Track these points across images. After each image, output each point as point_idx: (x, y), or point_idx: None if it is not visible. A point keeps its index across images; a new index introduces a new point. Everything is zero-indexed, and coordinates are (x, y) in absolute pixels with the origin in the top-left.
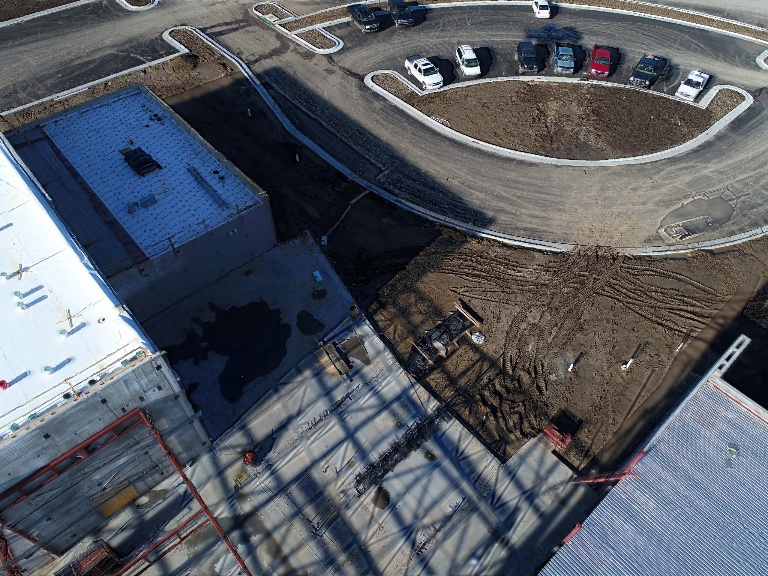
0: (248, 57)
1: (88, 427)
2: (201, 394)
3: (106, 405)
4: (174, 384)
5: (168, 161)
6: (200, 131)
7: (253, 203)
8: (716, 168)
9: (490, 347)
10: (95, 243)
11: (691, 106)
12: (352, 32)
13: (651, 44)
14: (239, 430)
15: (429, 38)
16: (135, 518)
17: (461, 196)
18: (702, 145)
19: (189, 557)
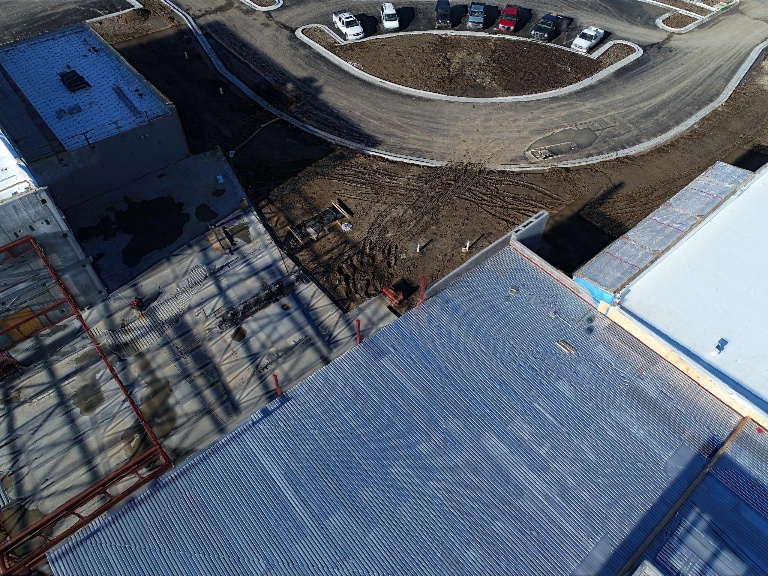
0: (195, 12)
1: None
2: (106, 261)
3: None
4: (61, 222)
5: (98, 82)
6: (141, 70)
7: (163, 113)
8: (592, 106)
9: (355, 233)
10: (24, 139)
11: (584, 56)
12: None
13: (563, 6)
14: (132, 286)
15: None
16: (38, 343)
17: (360, 123)
18: (585, 88)
19: (76, 369)
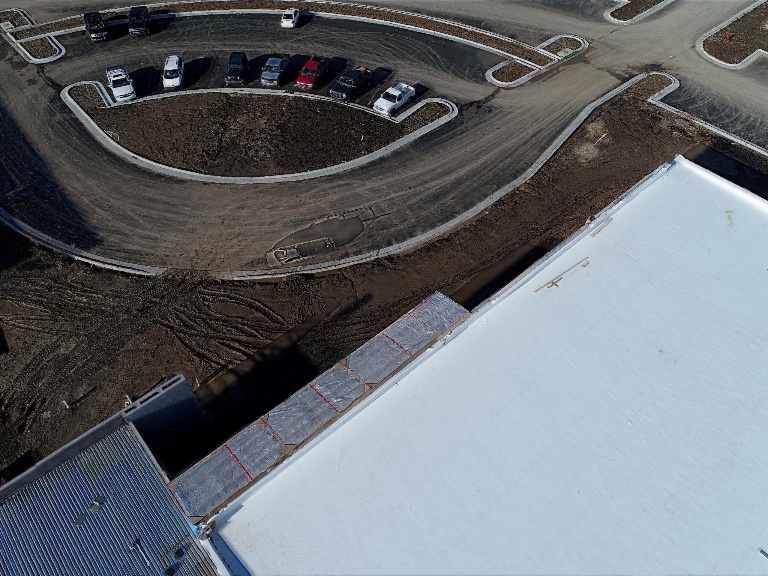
0: None
1: None
2: None
3: None
4: None
5: None
6: None
7: None
8: (372, 186)
9: None
10: None
11: (386, 120)
12: (82, 41)
13: (386, 55)
14: None
15: (158, 48)
16: None
17: (82, 215)
18: (373, 161)
19: None
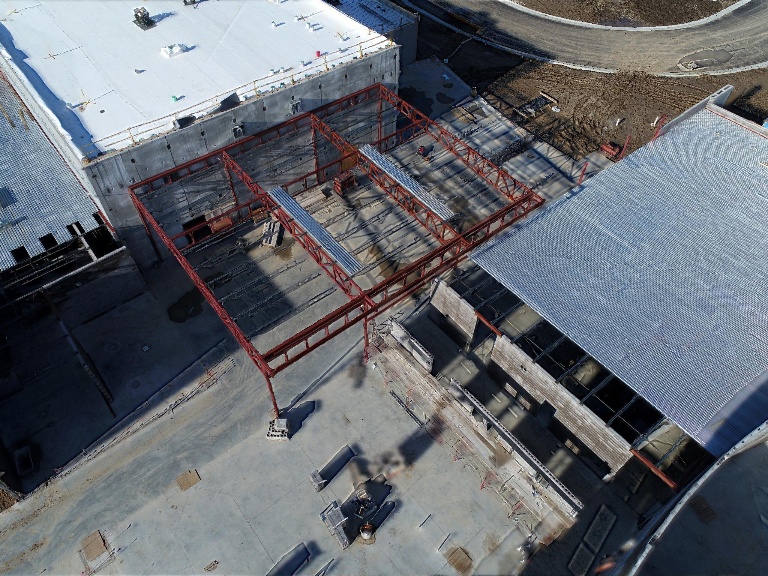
0: None
1: (360, 82)
2: None
3: (370, 70)
4: (397, 76)
5: (345, 1)
6: None
7: (407, 23)
8: (721, 34)
9: (564, 113)
10: None
11: None
12: None
13: None
14: (410, 142)
15: None
16: (357, 174)
17: (537, 43)
18: (712, 22)
19: None
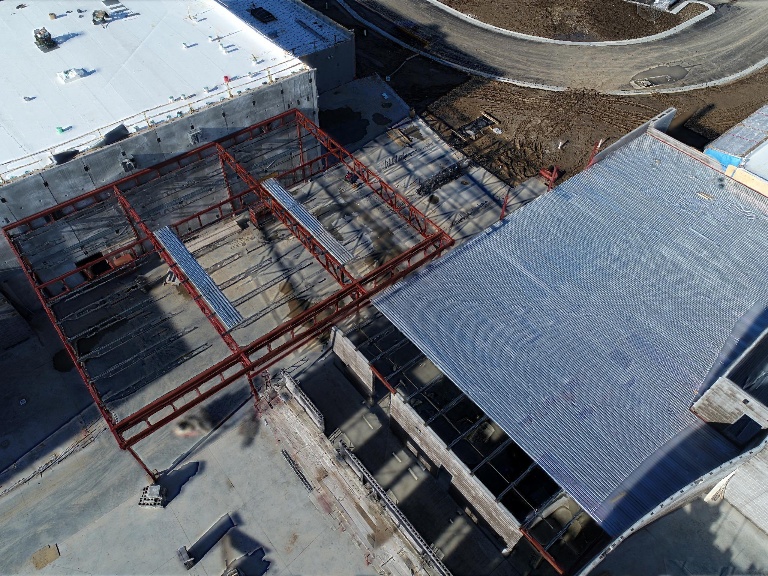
0: None
1: (271, 109)
2: None
3: (282, 96)
4: (315, 100)
5: (281, 16)
6: None
7: (344, 40)
8: (679, 49)
9: (505, 135)
10: None
11: (665, 12)
12: None
13: None
14: (339, 167)
15: None
16: None
17: (486, 59)
18: (670, 36)
19: None
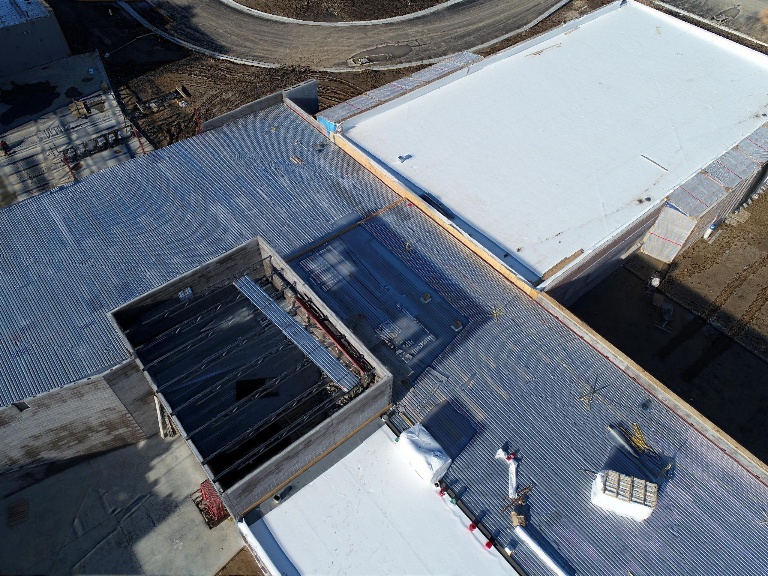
0: None
1: None
2: None
3: None
4: None
5: None
6: None
7: (44, 16)
8: (417, 29)
9: (188, 108)
10: None
11: None
12: None
13: None
14: (3, 137)
15: None
16: None
17: (220, 38)
18: (418, 17)
19: None
